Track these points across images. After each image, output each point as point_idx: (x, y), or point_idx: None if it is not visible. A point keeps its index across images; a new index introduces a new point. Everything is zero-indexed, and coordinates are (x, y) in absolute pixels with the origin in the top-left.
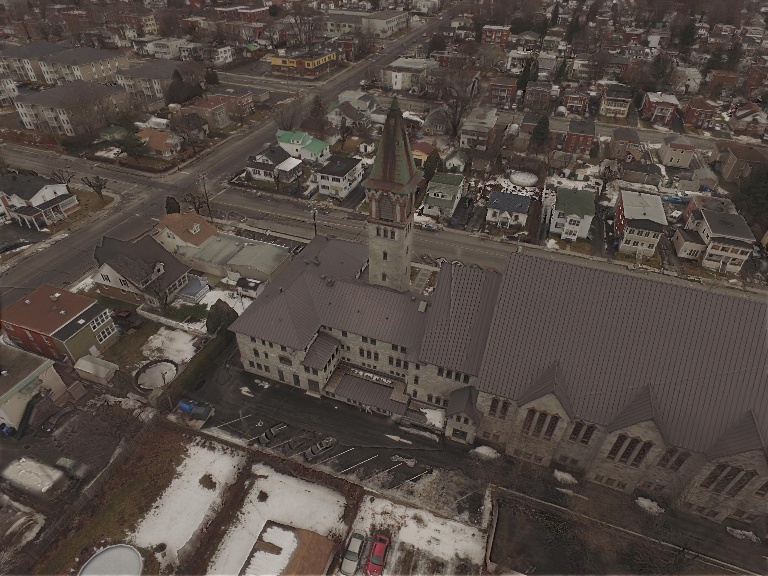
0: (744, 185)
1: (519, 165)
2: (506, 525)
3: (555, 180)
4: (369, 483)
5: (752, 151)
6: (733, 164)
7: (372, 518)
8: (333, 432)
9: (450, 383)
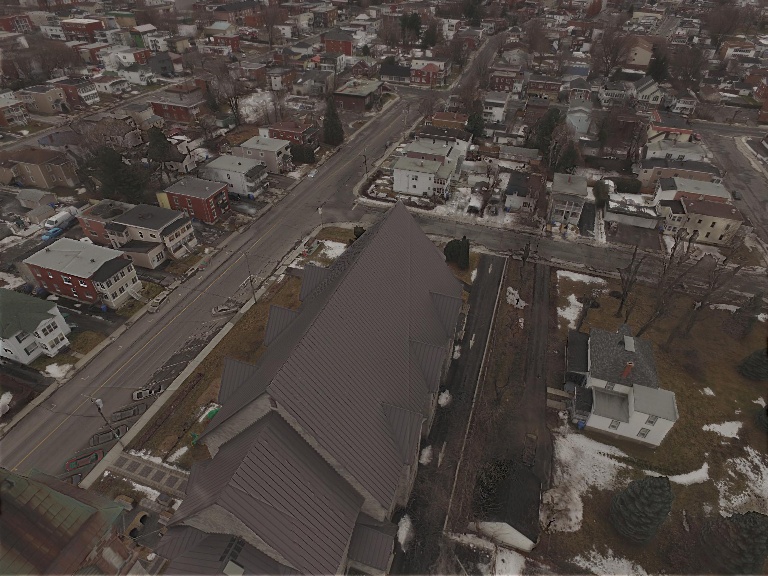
0: (108, 180)
1: None
2: (512, 516)
3: None
4: None
5: (39, 151)
6: (39, 171)
7: None
8: None
9: (344, 553)
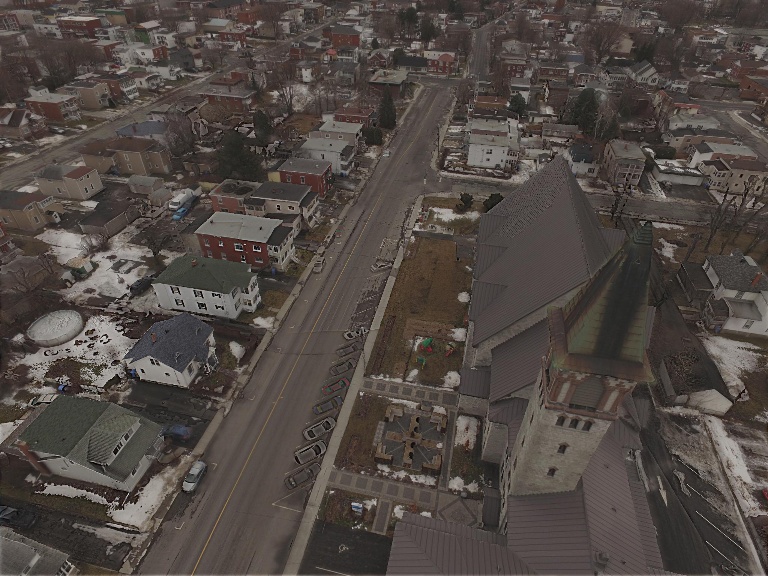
0: (236, 160)
1: (6, 325)
2: (715, 385)
3: (78, 294)
4: (732, 515)
5: (137, 139)
6: (140, 159)
7: (756, 510)
8: (705, 574)
9: None
